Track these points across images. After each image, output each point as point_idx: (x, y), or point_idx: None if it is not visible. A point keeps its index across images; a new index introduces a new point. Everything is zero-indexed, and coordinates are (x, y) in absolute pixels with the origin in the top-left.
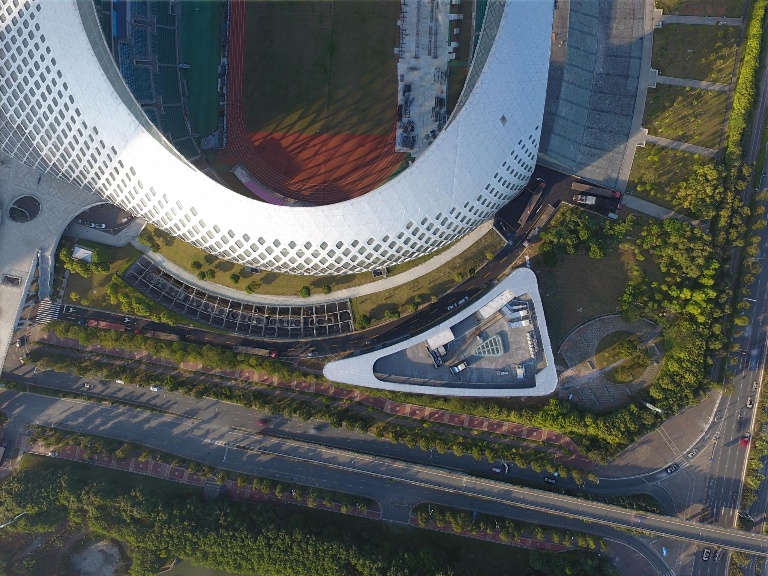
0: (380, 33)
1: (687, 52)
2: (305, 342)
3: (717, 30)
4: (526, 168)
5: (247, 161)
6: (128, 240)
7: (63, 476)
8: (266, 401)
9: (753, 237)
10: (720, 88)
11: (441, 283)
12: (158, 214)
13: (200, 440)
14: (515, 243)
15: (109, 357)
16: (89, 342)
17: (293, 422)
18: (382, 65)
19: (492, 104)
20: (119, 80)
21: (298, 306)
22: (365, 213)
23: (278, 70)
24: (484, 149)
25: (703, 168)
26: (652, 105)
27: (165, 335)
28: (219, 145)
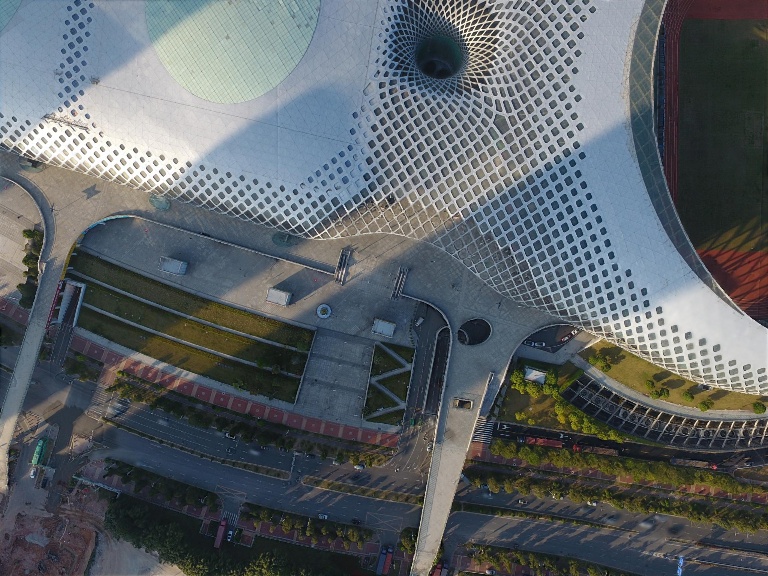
0: None
1: None
2: (740, 452)
3: None
4: None
5: None
6: (567, 358)
7: None
8: (705, 512)
9: None
10: None
11: None
12: (663, 347)
13: (638, 552)
14: None
15: (545, 473)
16: (540, 462)
17: (730, 531)
18: None
19: None
20: (679, 230)
21: (744, 420)
22: None
23: (712, 189)
24: None
25: None
26: None
27: (603, 450)
28: None
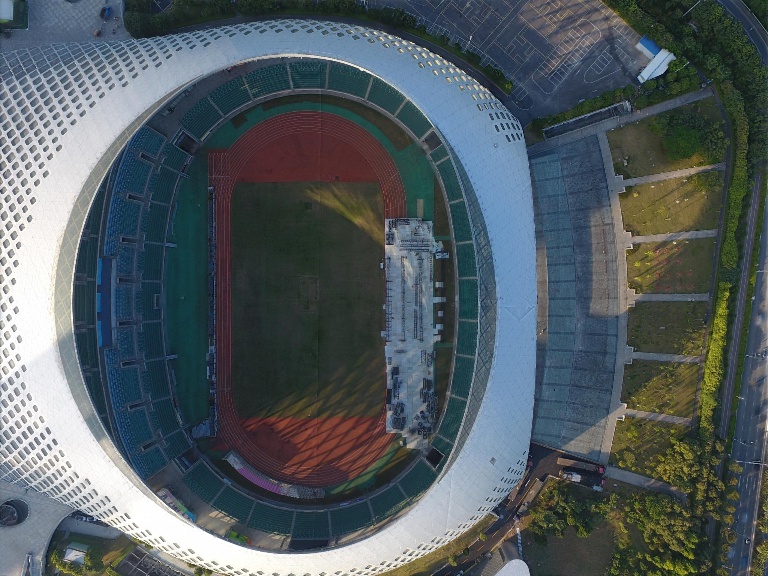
0: (366, 317)
1: (660, 328)
2: None
3: (686, 306)
4: (515, 481)
5: (239, 447)
6: (121, 531)
7: None
8: None
9: (728, 507)
10: (691, 360)
11: (436, 562)
12: (154, 545)
13: None
14: (506, 517)
15: None
16: None
17: None
18: (370, 348)
19: (482, 452)
20: (111, 448)
21: None
22: (363, 552)
23: (267, 356)
24: (476, 487)
25: (679, 446)
26: (629, 380)
27: None
28: (210, 434)
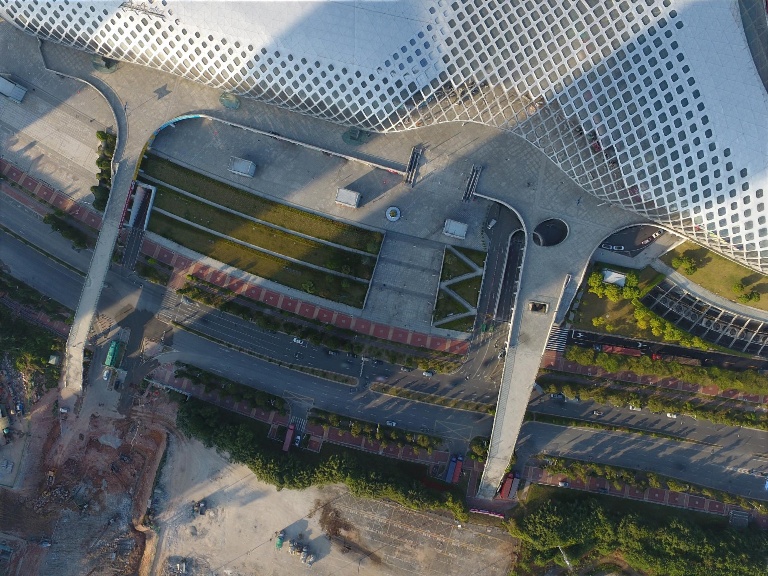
0: None
1: None
2: None
3: None
4: None
5: None
6: (647, 262)
7: (597, 508)
8: None
9: None
10: None
11: None
12: (761, 237)
13: (721, 468)
14: None
15: (622, 383)
16: (618, 369)
17: None
18: None
19: None
20: None
21: None
22: None
23: None
24: None
25: None
26: None
27: (685, 360)
28: None
